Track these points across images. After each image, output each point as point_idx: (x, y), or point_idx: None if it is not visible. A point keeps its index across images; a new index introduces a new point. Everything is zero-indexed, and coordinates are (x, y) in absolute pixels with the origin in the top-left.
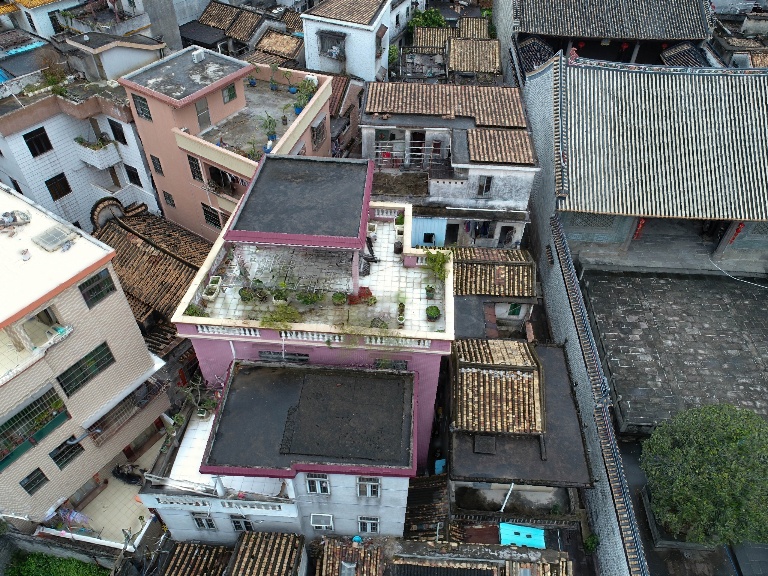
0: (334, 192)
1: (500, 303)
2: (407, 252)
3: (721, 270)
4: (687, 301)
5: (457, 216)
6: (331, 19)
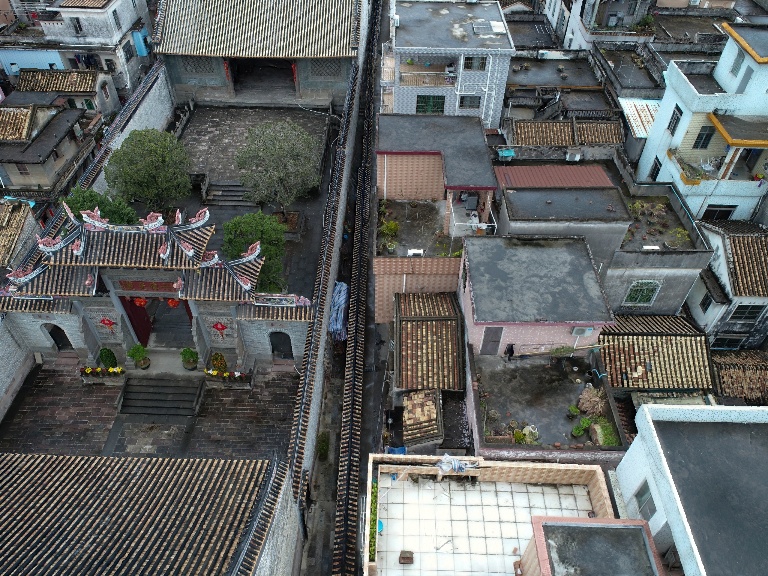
0: None
1: (77, 99)
2: None
3: (297, 104)
4: (259, 120)
5: (64, 49)
6: None
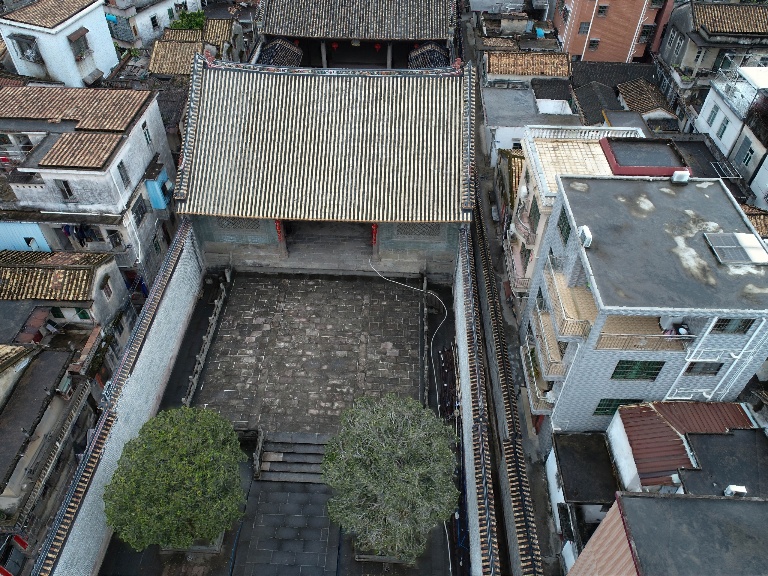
0: None
1: None
2: None
3: (375, 271)
4: (324, 302)
5: (46, 220)
6: (18, 22)
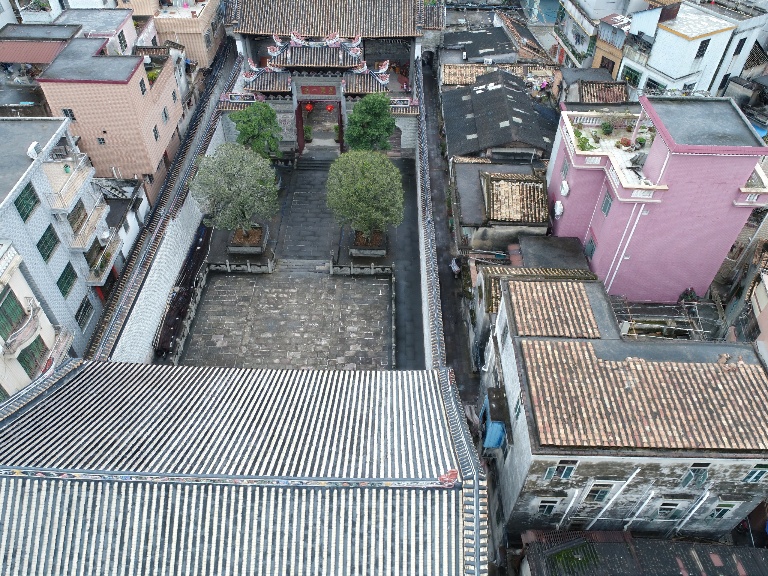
0: (685, 128)
1: None
2: (610, 152)
3: None
4: None
5: None
6: None
